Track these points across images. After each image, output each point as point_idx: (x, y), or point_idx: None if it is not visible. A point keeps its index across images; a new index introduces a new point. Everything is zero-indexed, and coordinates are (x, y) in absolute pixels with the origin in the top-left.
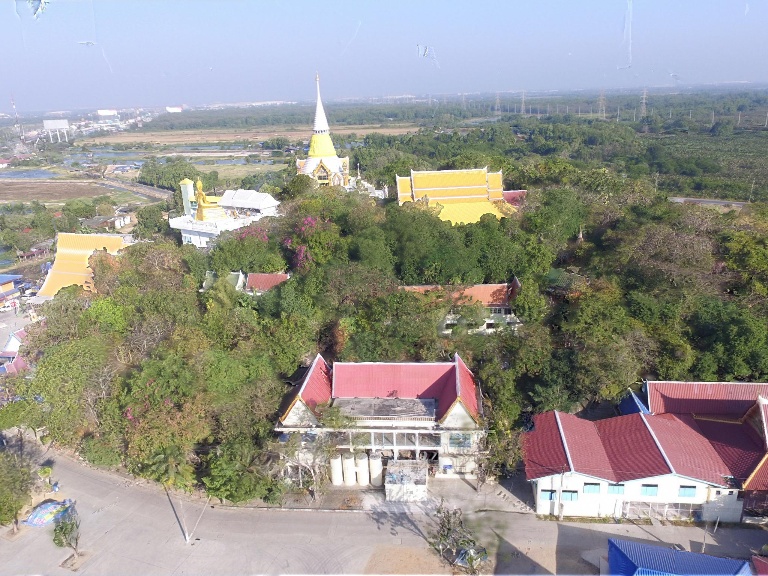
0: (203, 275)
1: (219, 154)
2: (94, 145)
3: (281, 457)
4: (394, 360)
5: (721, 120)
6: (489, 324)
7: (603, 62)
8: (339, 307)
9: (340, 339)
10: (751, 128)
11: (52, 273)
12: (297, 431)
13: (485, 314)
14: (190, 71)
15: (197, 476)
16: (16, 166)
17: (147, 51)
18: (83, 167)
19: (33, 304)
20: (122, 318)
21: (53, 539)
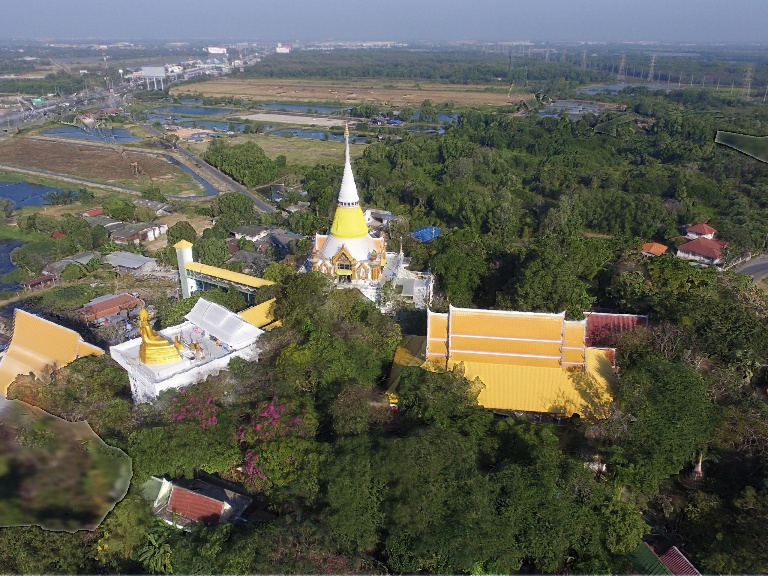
0: None
1: (304, 119)
2: (188, 95)
3: None
4: None
5: None
6: None
7: None
8: None
9: None
10: None
11: (6, 358)
12: None
13: None
14: None
15: None
16: None
17: None
18: (163, 129)
19: None
20: None
21: None
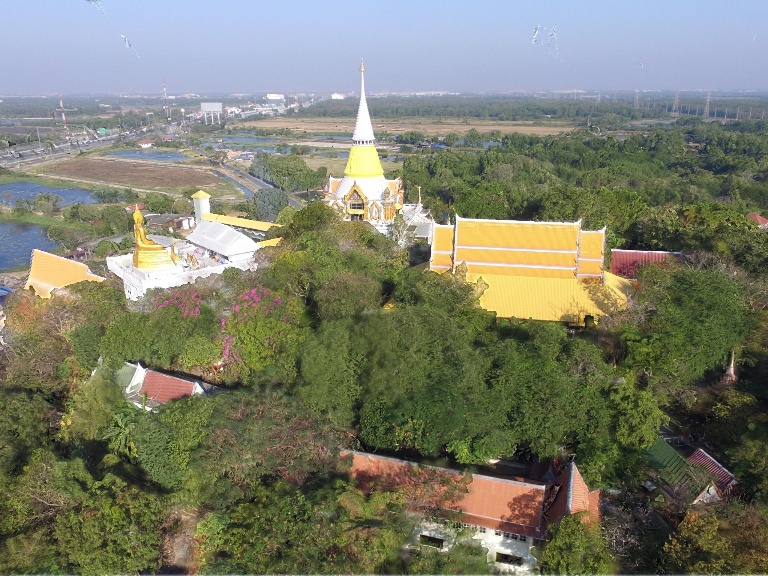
0: (92, 360)
1: (350, 146)
2: (242, 129)
3: None
4: None
5: None
6: (501, 554)
7: None
8: (216, 484)
9: (196, 554)
10: None
11: None
12: None
13: (473, 567)
14: None
15: None
16: (159, 146)
17: None
18: (214, 152)
19: None
20: None
21: None
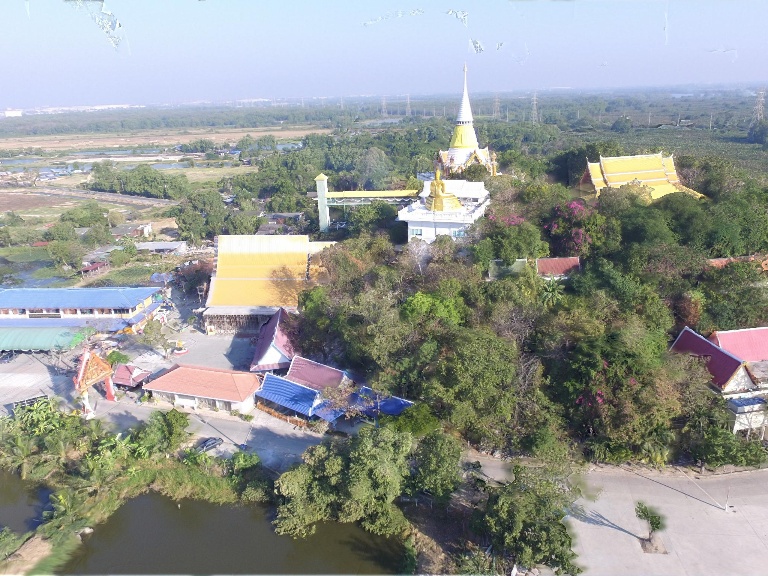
0: (489, 264)
1: (137, 159)
2: None
3: (736, 422)
4: (752, 326)
5: (620, 119)
6: None
7: (725, 57)
8: (674, 282)
9: (692, 311)
10: (640, 126)
11: (217, 281)
12: (733, 397)
13: None
14: (754, 44)
15: (670, 451)
16: None
17: (709, 23)
18: None
19: (214, 315)
20: (456, 311)
21: (654, 524)
